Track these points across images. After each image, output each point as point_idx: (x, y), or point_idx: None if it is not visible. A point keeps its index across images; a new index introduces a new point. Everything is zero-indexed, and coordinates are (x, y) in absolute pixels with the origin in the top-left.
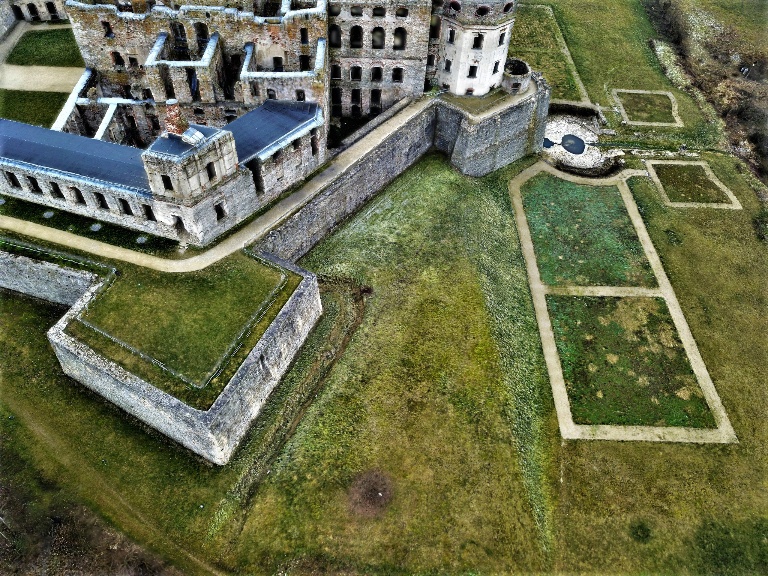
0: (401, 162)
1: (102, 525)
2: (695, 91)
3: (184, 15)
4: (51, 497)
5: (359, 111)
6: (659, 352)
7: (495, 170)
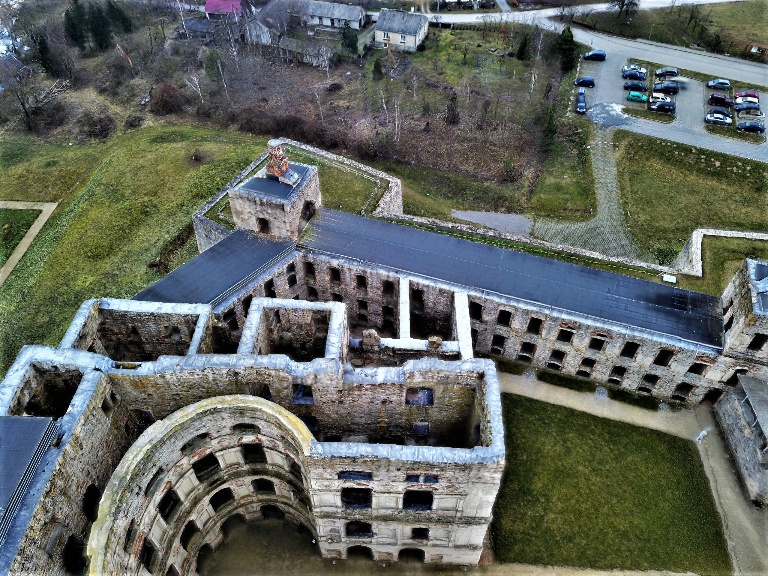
0: None
1: (353, 158)
2: None
3: None
4: (385, 165)
5: None
6: None
7: None
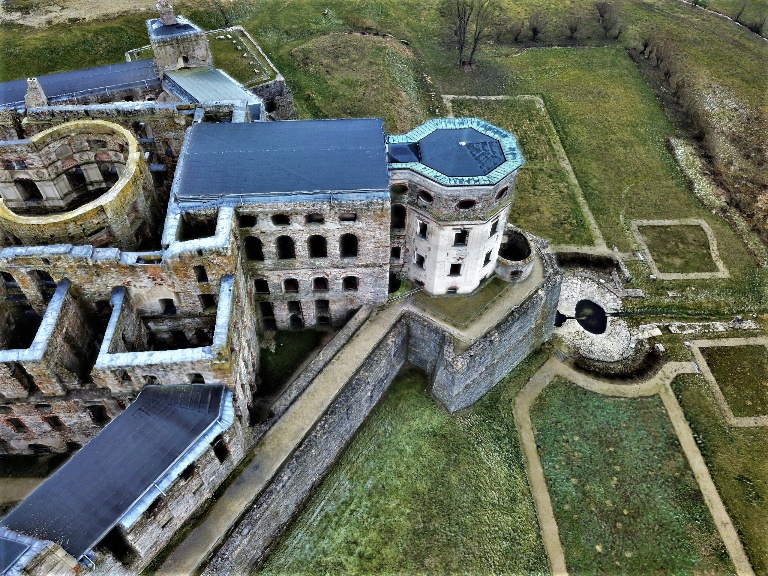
0: (361, 411)
1: None
2: (733, 215)
3: (8, 263)
4: None
5: (300, 322)
6: None
7: (493, 386)
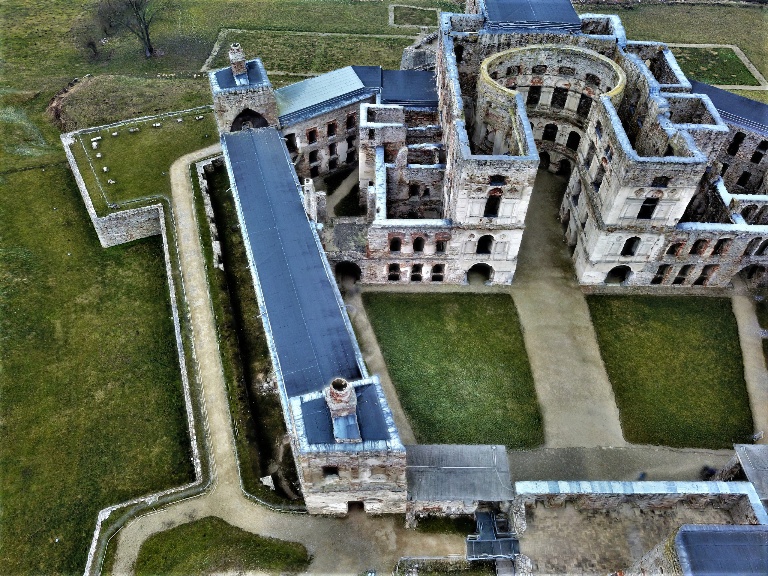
0: None
1: None
2: None
3: None
4: None
5: None
6: (688, 54)
7: None
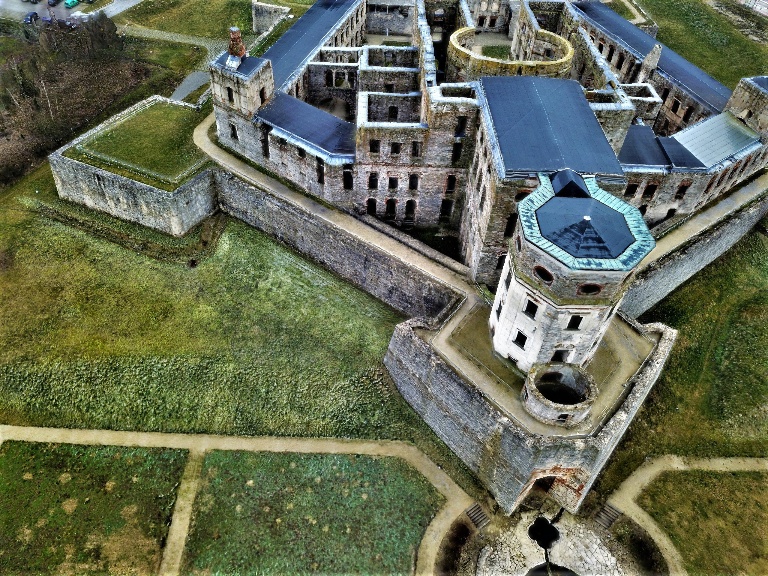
0: (379, 287)
1: None
2: None
3: None
4: None
5: None
6: (57, 572)
7: (425, 421)
